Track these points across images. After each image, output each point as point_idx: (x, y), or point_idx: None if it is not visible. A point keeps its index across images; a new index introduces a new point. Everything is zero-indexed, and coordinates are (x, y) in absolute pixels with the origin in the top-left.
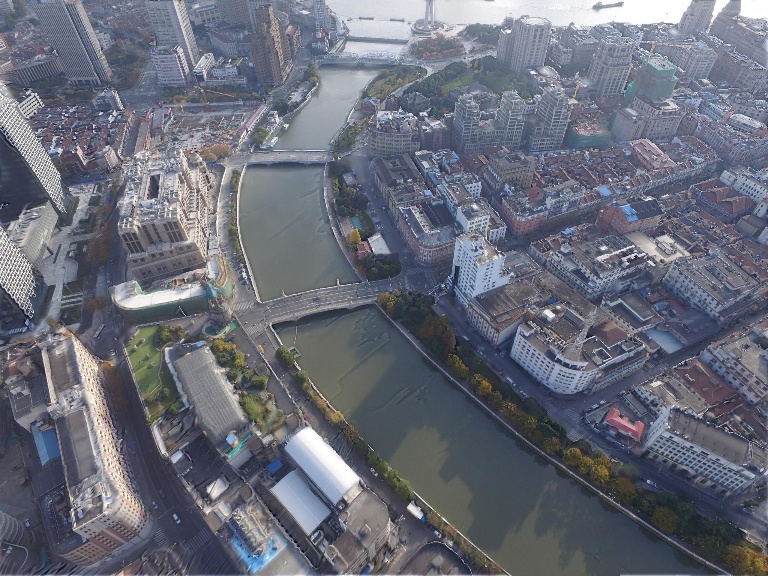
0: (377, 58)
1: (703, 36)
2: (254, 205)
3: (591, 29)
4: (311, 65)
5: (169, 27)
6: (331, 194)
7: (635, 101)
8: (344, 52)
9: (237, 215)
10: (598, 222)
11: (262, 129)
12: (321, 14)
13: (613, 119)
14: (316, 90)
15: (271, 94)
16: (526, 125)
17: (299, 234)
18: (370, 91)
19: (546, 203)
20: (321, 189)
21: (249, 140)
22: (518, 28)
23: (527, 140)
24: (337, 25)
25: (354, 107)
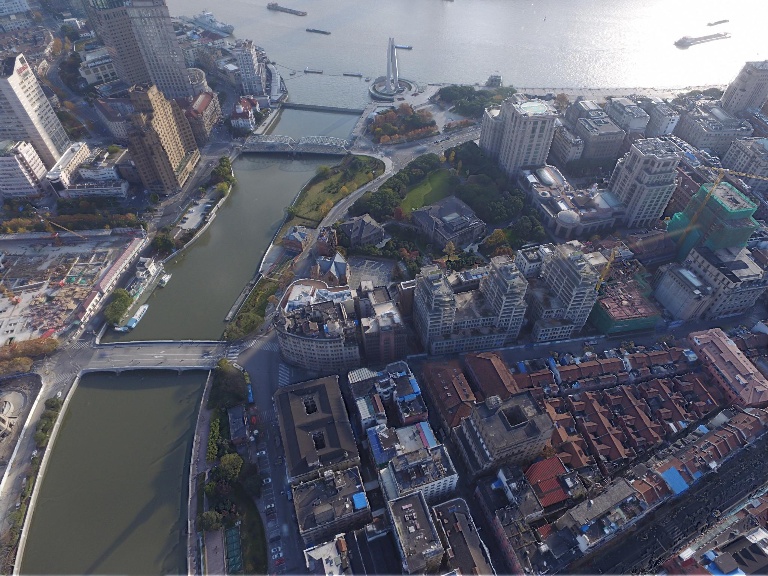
0: (318, 143)
1: (760, 121)
2: (83, 458)
3: (605, 104)
4: (222, 160)
5: (10, 113)
6: (203, 457)
7: (692, 255)
8: (272, 135)
9: (26, 519)
10: (673, 568)
11: (121, 295)
12: (249, 73)
13: (658, 280)
14: (227, 200)
15: (159, 210)
16: (528, 298)
17: (127, 575)
18: (301, 205)
19: (578, 541)
20: (189, 441)
21: (101, 312)
22: (509, 115)
23: (529, 318)
24: (272, 85)
25: (274, 239)
